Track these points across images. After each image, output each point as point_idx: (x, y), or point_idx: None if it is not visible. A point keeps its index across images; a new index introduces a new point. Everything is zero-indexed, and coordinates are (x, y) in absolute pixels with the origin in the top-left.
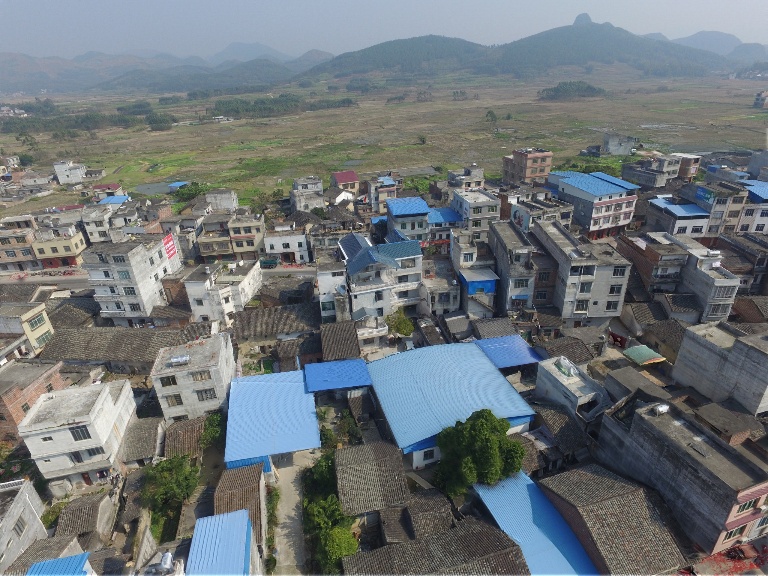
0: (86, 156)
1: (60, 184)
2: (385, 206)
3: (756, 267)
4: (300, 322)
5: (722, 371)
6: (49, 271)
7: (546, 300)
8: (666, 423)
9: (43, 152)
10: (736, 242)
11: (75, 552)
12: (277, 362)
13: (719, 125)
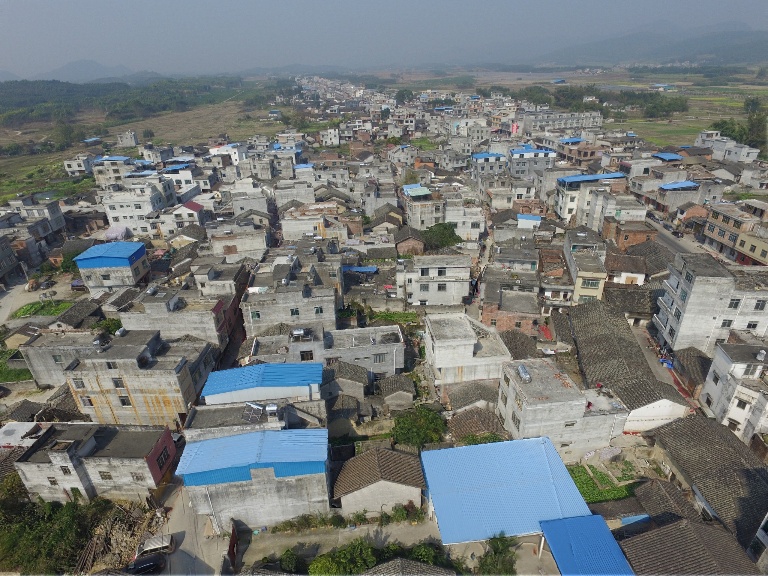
0: None
1: None
2: None
3: None
4: (735, 506)
5: None
6: None
7: None
8: None
9: None
10: None
11: (357, 389)
12: None
13: None
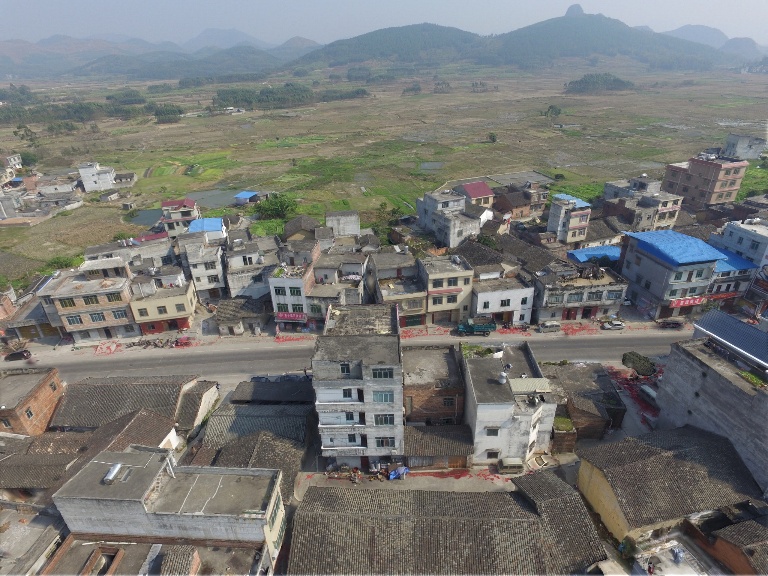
0: (97, 154)
1: (86, 192)
2: (574, 234)
3: None
4: (721, 485)
5: None
6: (152, 339)
7: None
8: None
9: (45, 149)
10: None
11: None
12: (723, 574)
13: None
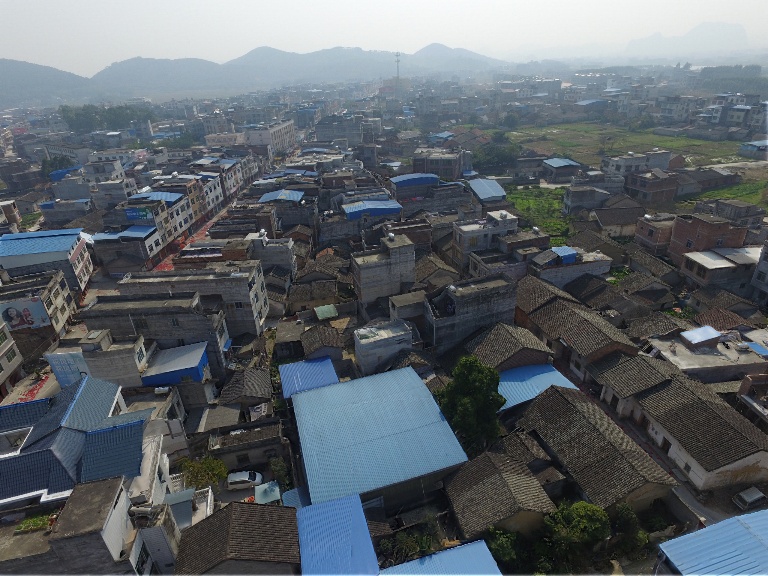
0: None
1: None
2: None
3: None
4: None
5: (391, 273)
6: None
7: None
8: (461, 292)
9: None
10: (229, 228)
11: None
12: None
13: None
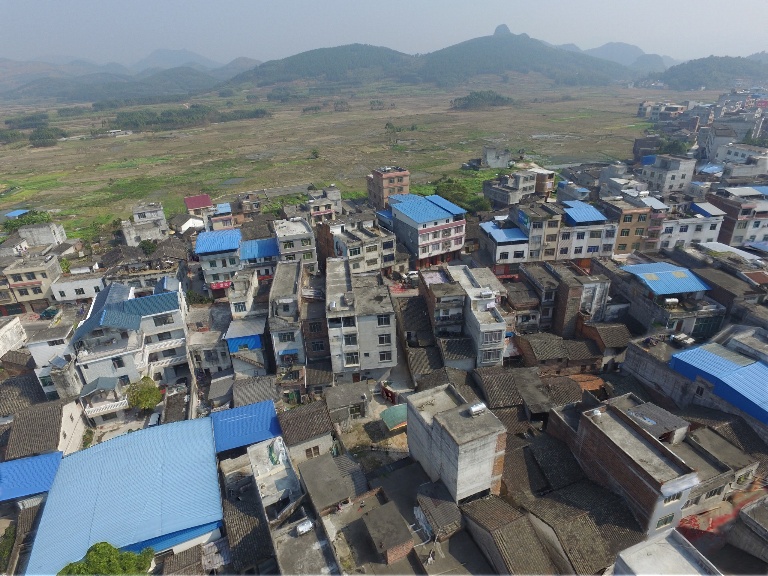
0: None
1: None
2: None
3: (544, 301)
4: (22, 400)
5: (431, 449)
6: None
7: (324, 351)
8: (304, 547)
9: None
10: (529, 274)
11: None
12: None
13: (601, 135)
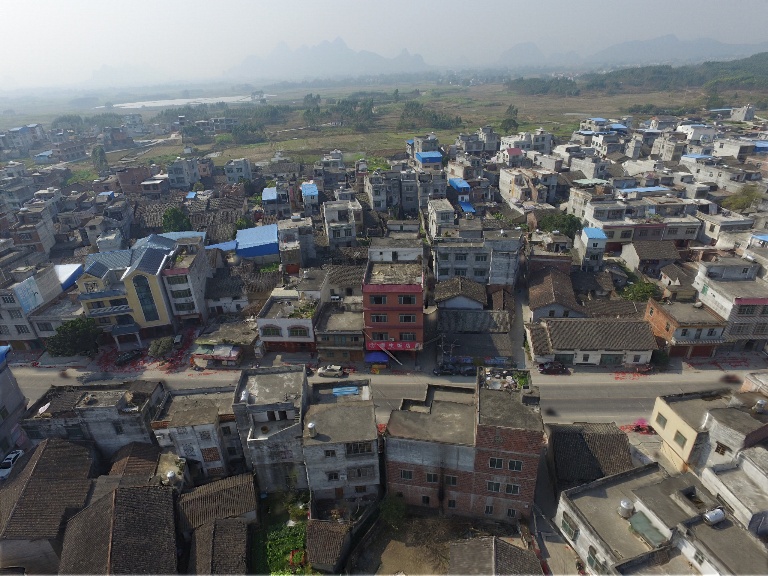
0: None
1: None
2: None
3: None
4: None
5: None
6: None
7: None
8: None
9: None
10: None
11: None
12: None
13: None
